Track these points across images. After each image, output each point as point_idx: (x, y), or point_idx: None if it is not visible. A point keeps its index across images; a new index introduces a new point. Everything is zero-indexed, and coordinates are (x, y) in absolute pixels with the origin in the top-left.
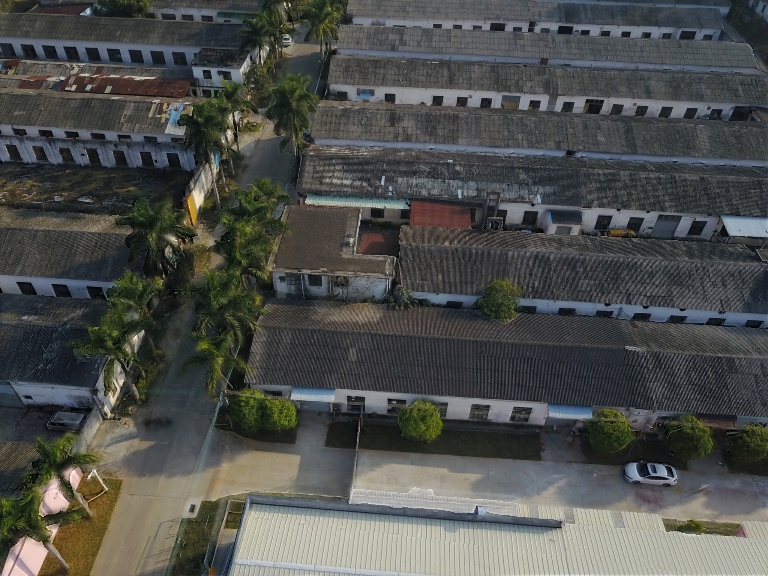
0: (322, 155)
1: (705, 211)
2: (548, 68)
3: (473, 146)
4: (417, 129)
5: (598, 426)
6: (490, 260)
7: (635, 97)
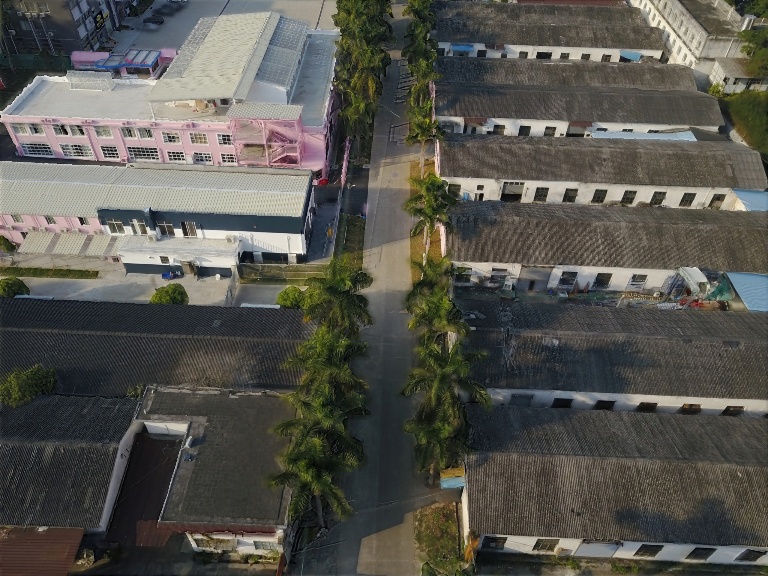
0: None
1: None
2: None
3: None
4: None
5: (19, 281)
6: (3, 428)
7: None
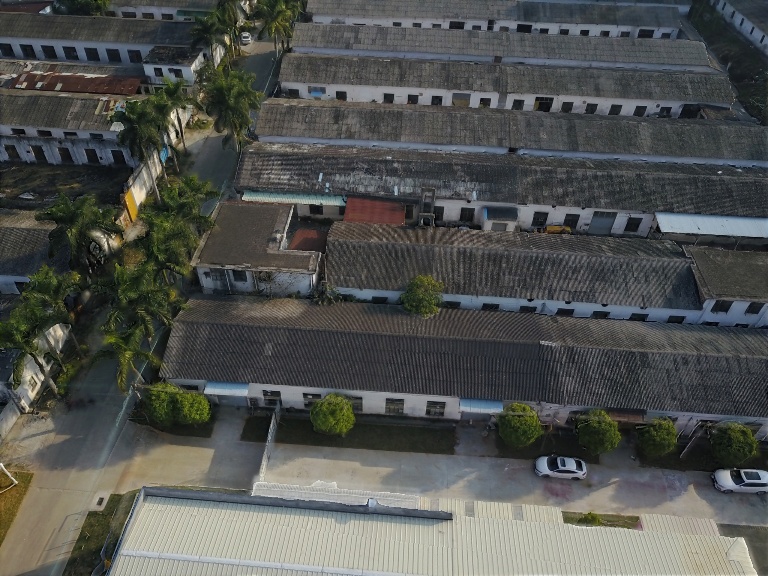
0: (261, 152)
1: (639, 208)
2: (499, 66)
3: (415, 143)
4: (361, 126)
5: (506, 420)
6: (416, 256)
7: (584, 95)
